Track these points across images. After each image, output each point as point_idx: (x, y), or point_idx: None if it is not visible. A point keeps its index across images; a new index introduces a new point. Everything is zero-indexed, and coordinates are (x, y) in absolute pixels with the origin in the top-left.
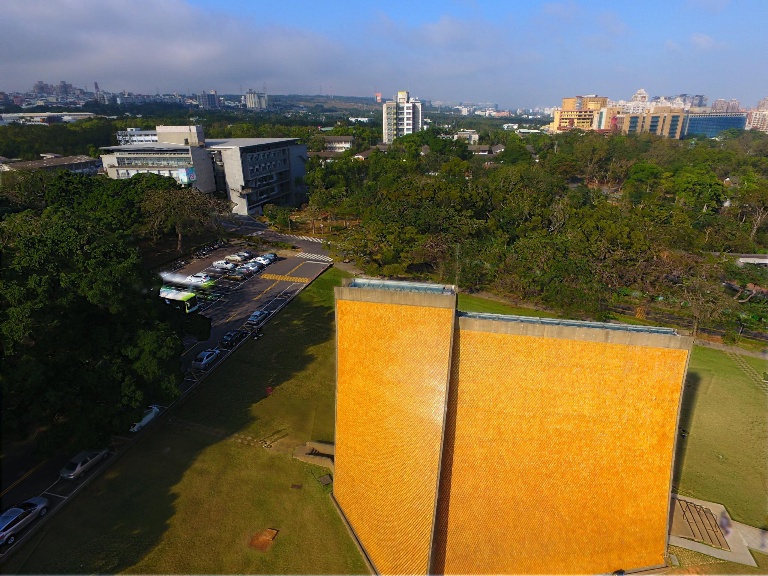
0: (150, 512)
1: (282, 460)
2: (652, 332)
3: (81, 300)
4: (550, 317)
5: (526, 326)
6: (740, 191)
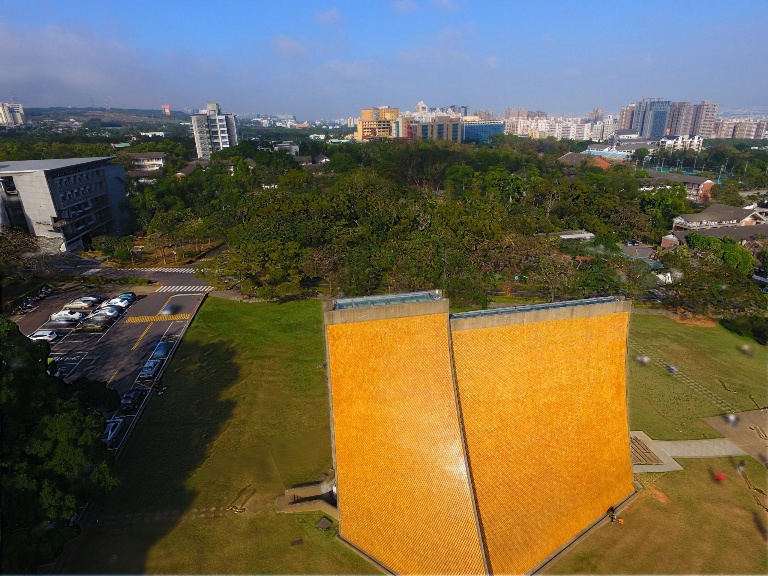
0: None
1: (265, 520)
2: (601, 302)
3: None
4: None
5: (509, 316)
6: None
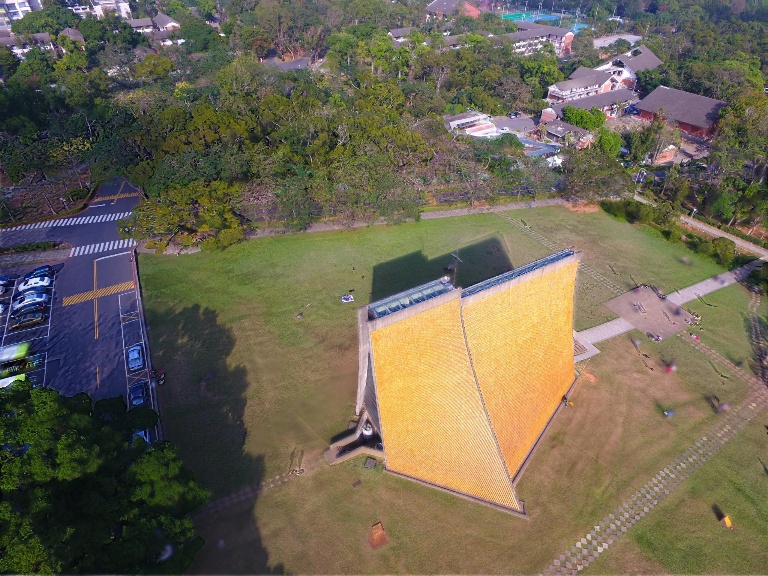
0: None
1: (324, 474)
2: None
3: (51, 486)
4: (382, 229)
5: (501, 286)
6: (414, 51)
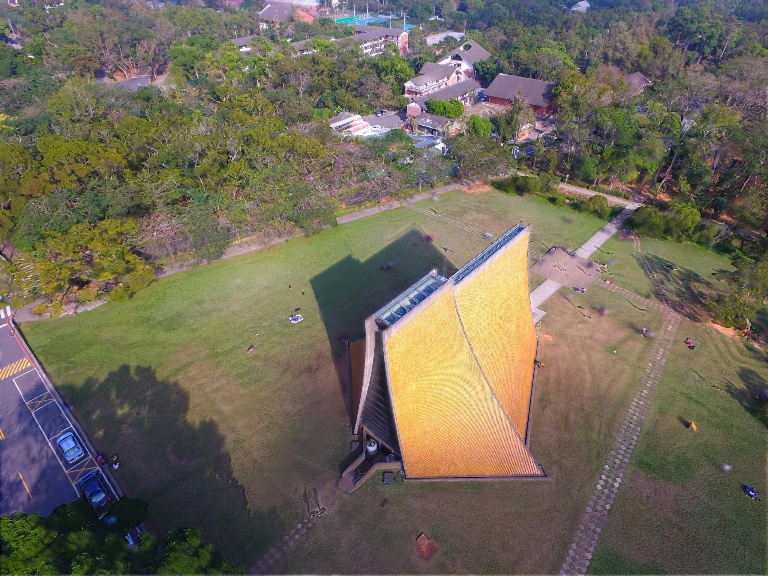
0: None
1: (347, 504)
2: None
3: None
4: (302, 241)
5: None
6: None
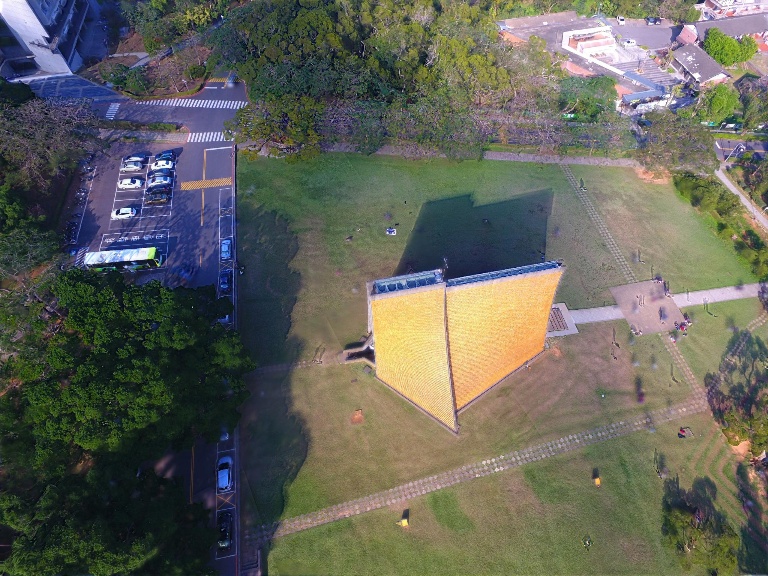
0: (288, 433)
1: (335, 368)
2: (546, 267)
3: (170, 351)
4: (444, 163)
5: (484, 282)
6: None
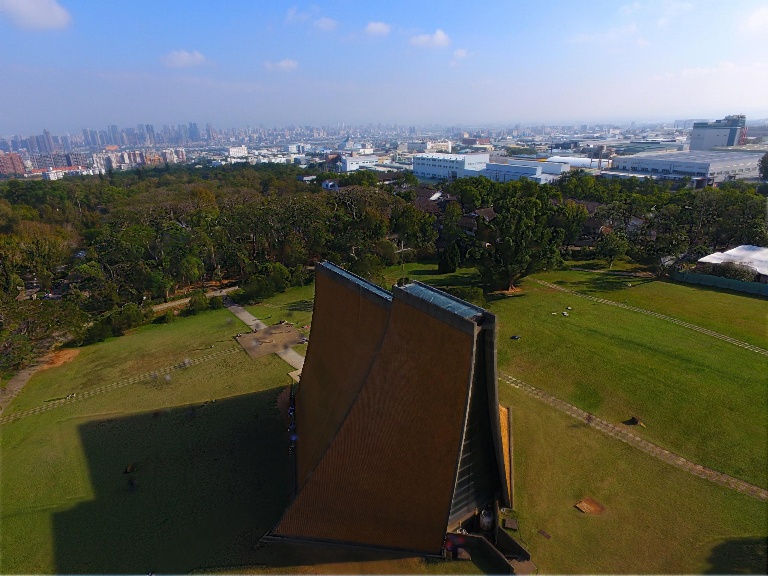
0: None
1: (553, 574)
2: None
3: None
4: None
5: None
6: None
